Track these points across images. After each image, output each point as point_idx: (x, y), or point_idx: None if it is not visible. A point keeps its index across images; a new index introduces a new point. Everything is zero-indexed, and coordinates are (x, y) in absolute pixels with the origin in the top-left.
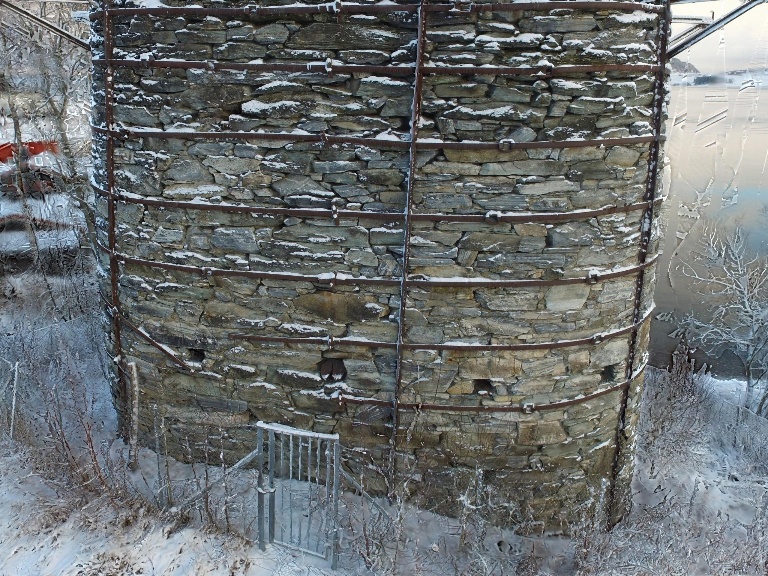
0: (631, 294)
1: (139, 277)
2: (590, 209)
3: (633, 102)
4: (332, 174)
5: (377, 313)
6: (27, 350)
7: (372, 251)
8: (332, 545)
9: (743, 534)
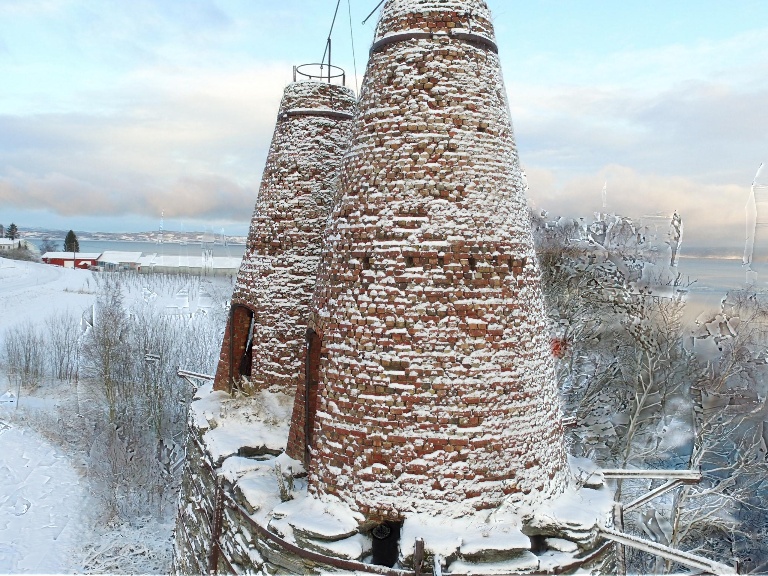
0: None
1: None
2: None
3: None
4: None
5: None
6: None
7: None
8: None
9: None
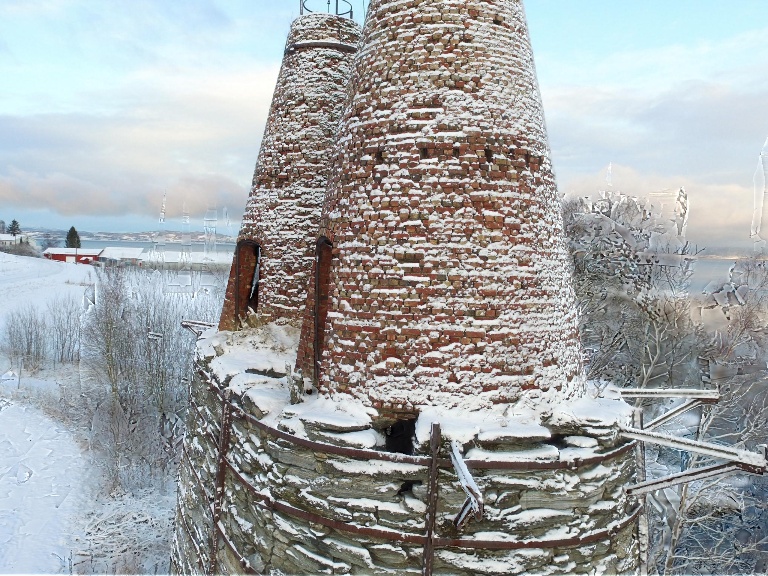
0: None
1: None
2: None
3: (371, 575)
4: None
5: None
6: None
7: None
8: None
9: None
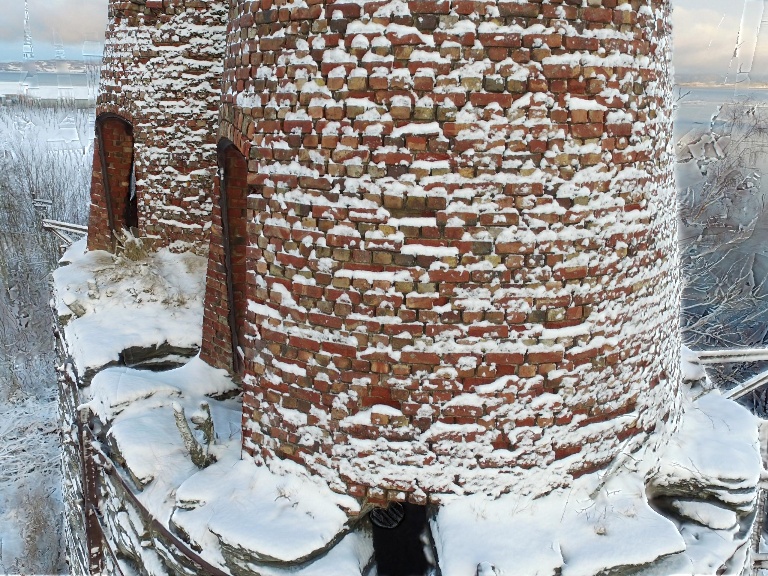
0: None
1: None
2: None
3: None
4: None
5: None
6: None
7: None
8: None
9: None
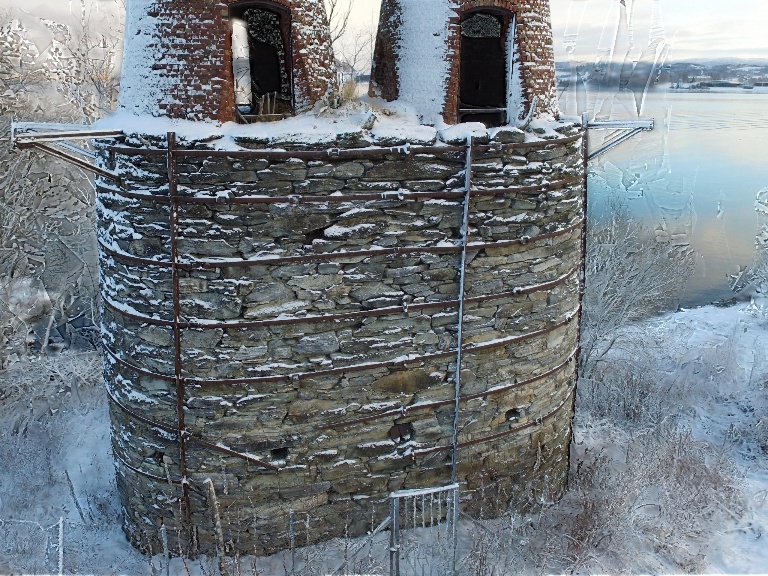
0: None
1: (215, 396)
2: (566, 274)
3: None
4: (402, 278)
5: (440, 379)
6: None
7: (434, 332)
8: (453, 571)
9: (622, 464)
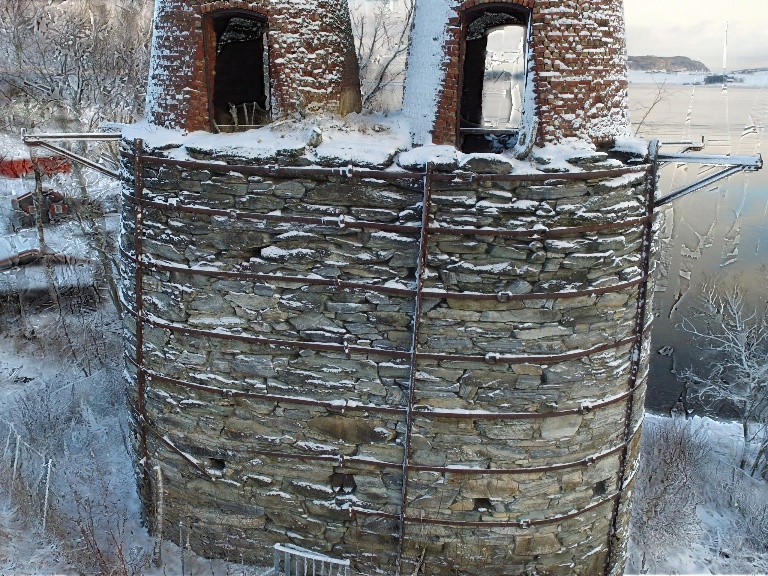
0: (621, 416)
1: (165, 392)
2: (582, 349)
3: (622, 252)
4: (344, 314)
5: (385, 437)
6: (53, 421)
7: (380, 382)
8: None
9: None
